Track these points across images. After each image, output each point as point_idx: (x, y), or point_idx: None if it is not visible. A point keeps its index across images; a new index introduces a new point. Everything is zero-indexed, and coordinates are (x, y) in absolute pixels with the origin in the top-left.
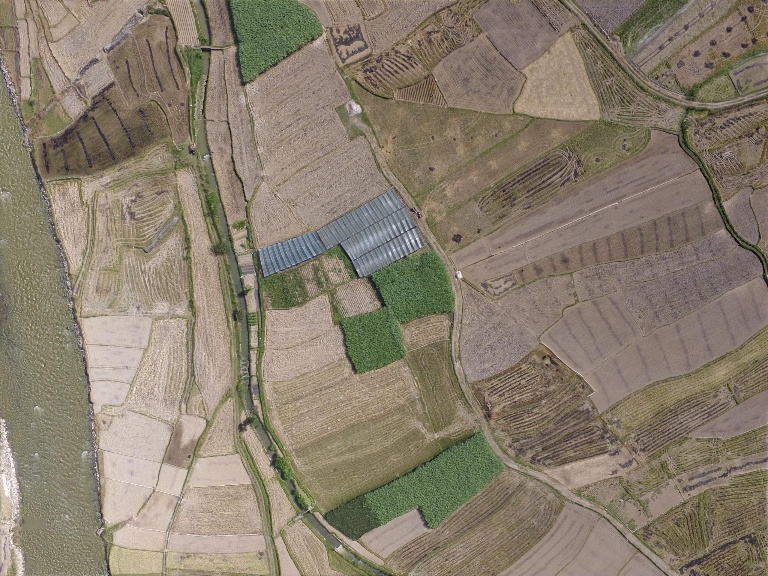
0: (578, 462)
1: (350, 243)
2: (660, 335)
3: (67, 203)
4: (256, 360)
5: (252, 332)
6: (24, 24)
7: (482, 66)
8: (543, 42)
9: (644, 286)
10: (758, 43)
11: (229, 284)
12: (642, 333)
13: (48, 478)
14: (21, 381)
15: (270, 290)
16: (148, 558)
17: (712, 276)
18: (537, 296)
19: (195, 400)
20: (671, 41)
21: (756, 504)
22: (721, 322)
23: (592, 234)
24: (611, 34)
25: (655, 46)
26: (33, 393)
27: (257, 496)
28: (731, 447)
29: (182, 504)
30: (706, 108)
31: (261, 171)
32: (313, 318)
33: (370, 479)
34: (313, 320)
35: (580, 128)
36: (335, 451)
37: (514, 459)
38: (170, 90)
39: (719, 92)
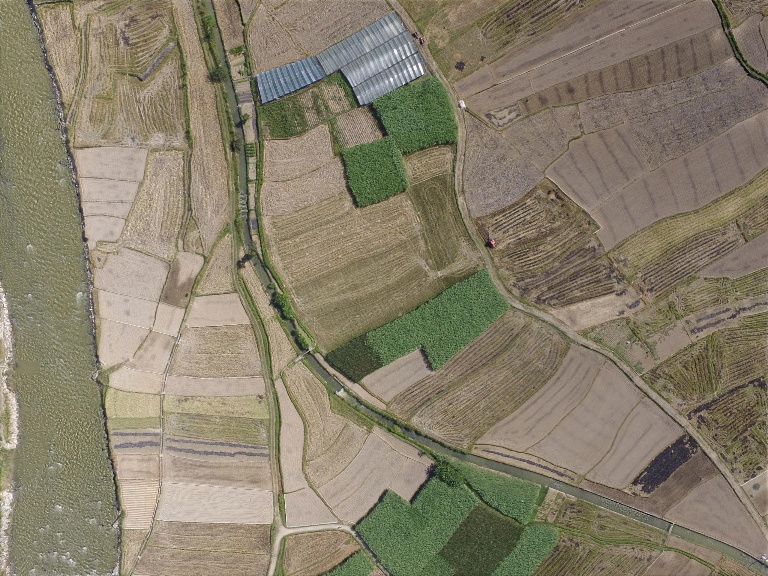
0: (584, 302)
1: (350, 68)
2: (668, 169)
3: (59, 28)
4: (254, 193)
5: (250, 164)
6: None
7: None
8: None
9: (651, 118)
10: None
11: (226, 113)
12: (649, 167)
13: (42, 320)
14: (13, 218)
15: (268, 119)
16: (145, 401)
17: (721, 107)
18: (542, 127)
19: (192, 236)
20: None
21: (765, 346)
22: (730, 156)
23: (598, 63)
24: None
25: None
26: (26, 230)
27: (256, 337)
28: (740, 287)
29: (179, 345)
30: None
31: None
32: (313, 149)
33: (372, 319)
34: (313, 151)
35: None
36: (336, 289)
37: (519, 299)
38: None
39: None
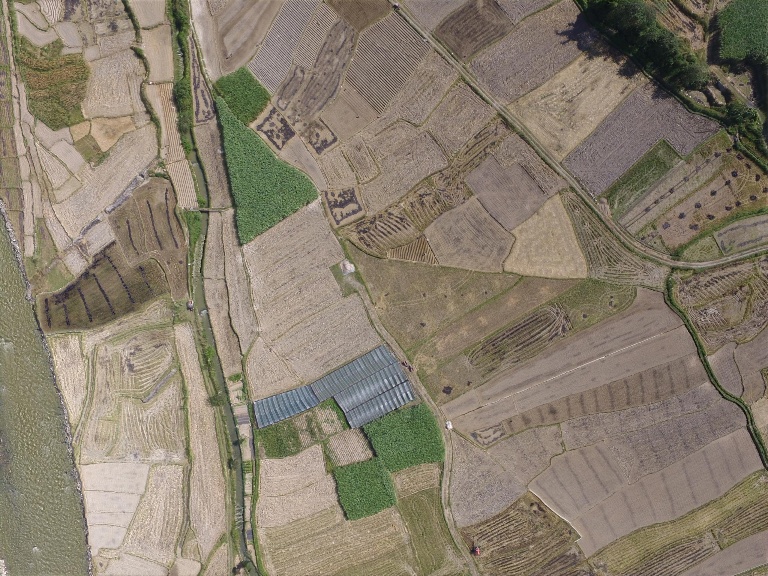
0: None
1: (343, 396)
2: (646, 483)
3: (68, 355)
4: (250, 506)
5: (246, 479)
6: (28, 185)
7: (473, 227)
8: (532, 204)
9: (630, 436)
10: (741, 206)
11: (224, 434)
12: (628, 481)
13: None
14: (20, 523)
15: (264, 440)
16: None
17: (697, 427)
18: (525, 445)
19: (190, 544)
20: (657, 203)
21: None
22: (705, 471)
23: (579, 386)
24: (598, 197)
25: (641, 208)
26: (32, 535)
27: None
28: None
29: None
30: (691, 268)
31: (257, 327)
32: (306, 467)
33: None
34: (306, 469)
35: (568, 286)
36: None
37: None
38: (169, 249)
39: (703, 252)
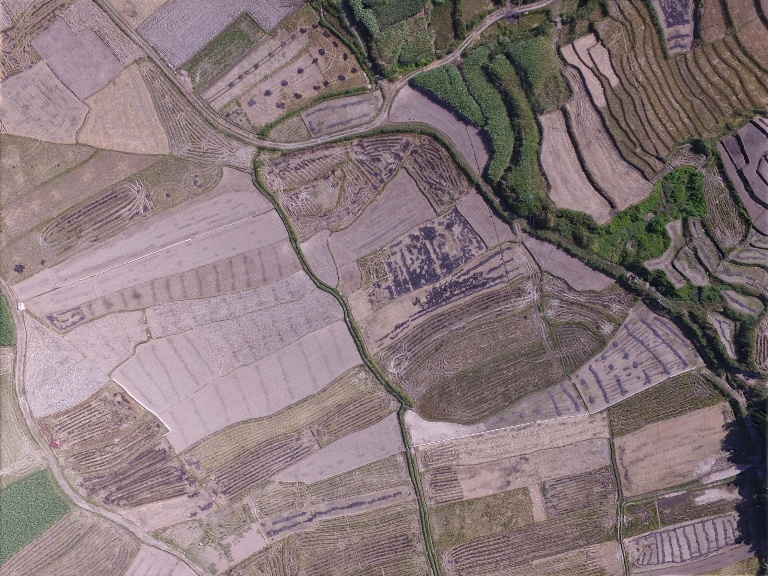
0: (154, 503)
1: None
2: (239, 375)
3: None
4: None
5: None
6: None
7: (43, 94)
8: (107, 73)
9: (221, 325)
10: (329, 86)
11: None
12: (219, 373)
13: None
14: None
15: None
16: None
17: (291, 317)
18: (107, 331)
19: None
20: (241, 79)
21: (342, 550)
22: (302, 364)
23: (165, 270)
24: (178, 69)
25: (225, 83)
26: None
27: None
28: (315, 491)
29: None
30: (277, 148)
31: None
32: None
33: None
34: None
35: (148, 162)
36: None
37: (85, 499)
38: None
39: (291, 133)
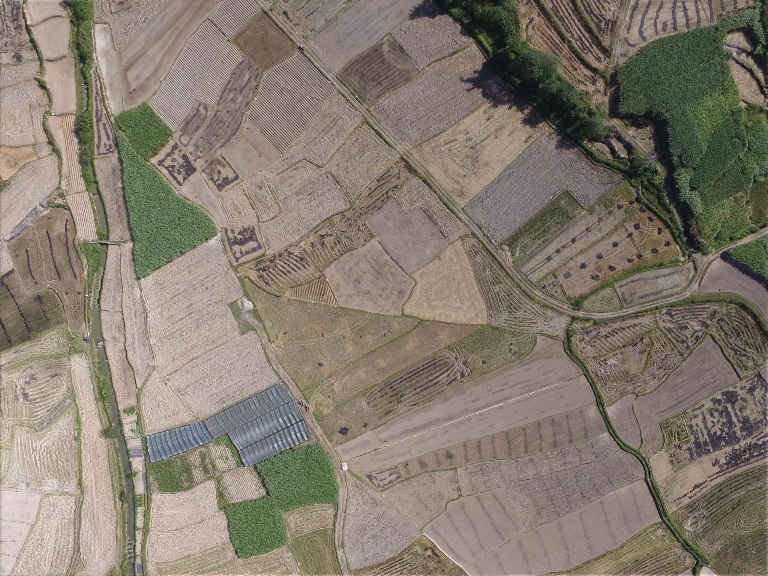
0: None
1: (237, 434)
2: (542, 531)
3: None
4: (141, 540)
5: (138, 513)
6: None
7: (373, 269)
8: (433, 248)
9: (527, 483)
10: (643, 259)
11: (117, 466)
12: (524, 529)
13: None
14: None
15: (157, 474)
16: None
17: (594, 477)
18: (421, 489)
19: (80, 575)
20: (558, 253)
21: None
22: (602, 521)
23: (477, 432)
24: (500, 244)
25: (543, 257)
26: None
27: None
28: None
29: None
30: (591, 318)
31: (152, 361)
32: (199, 503)
33: None
34: (199, 505)
35: (467, 331)
36: None
37: None
38: (67, 279)
39: (604, 303)
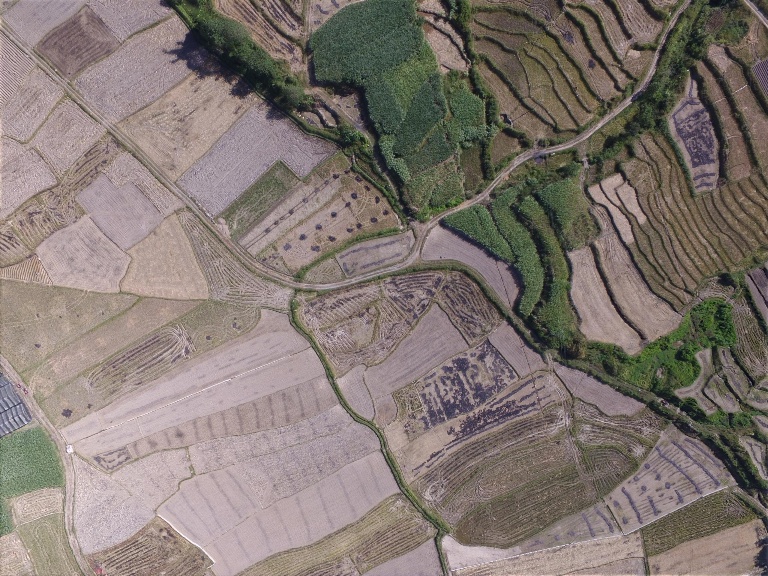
0: None
1: None
2: (280, 507)
3: None
4: None
5: None
6: None
7: (87, 246)
8: (148, 224)
9: (262, 459)
10: (362, 228)
11: None
12: (261, 505)
13: None
14: None
15: None
16: None
17: (329, 450)
18: (152, 470)
19: None
20: (277, 225)
21: None
22: (341, 494)
23: (206, 409)
24: (216, 217)
25: (261, 229)
26: None
27: None
28: None
29: None
30: (313, 290)
31: None
32: None
33: None
34: None
35: (189, 307)
36: None
37: None
38: None
39: (326, 274)
